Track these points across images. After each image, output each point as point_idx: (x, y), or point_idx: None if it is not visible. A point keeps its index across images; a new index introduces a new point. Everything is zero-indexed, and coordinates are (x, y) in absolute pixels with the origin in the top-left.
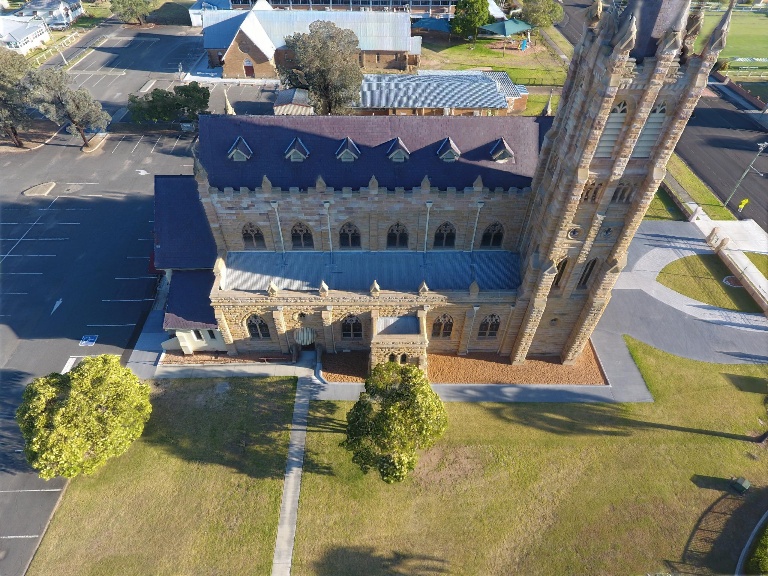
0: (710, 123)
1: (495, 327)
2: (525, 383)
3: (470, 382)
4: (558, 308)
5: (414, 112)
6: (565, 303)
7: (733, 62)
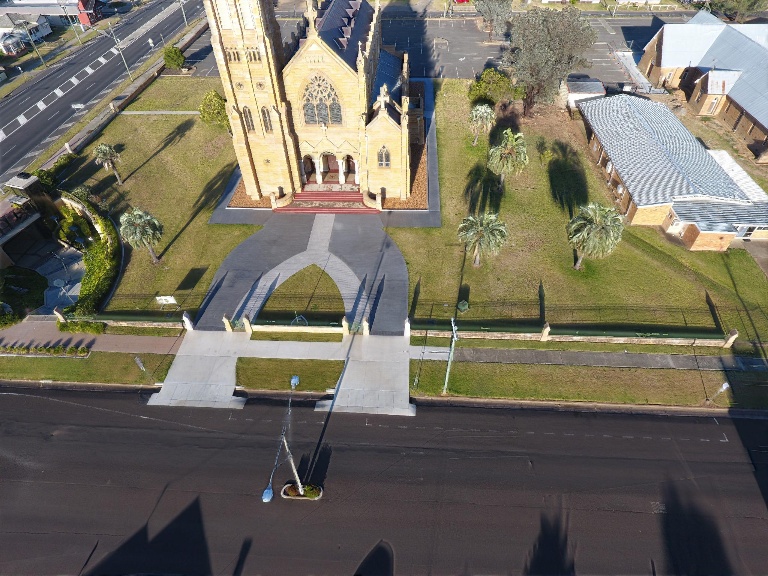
0: None
1: None
2: None
3: None
4: None
5: None
6: None
7: None
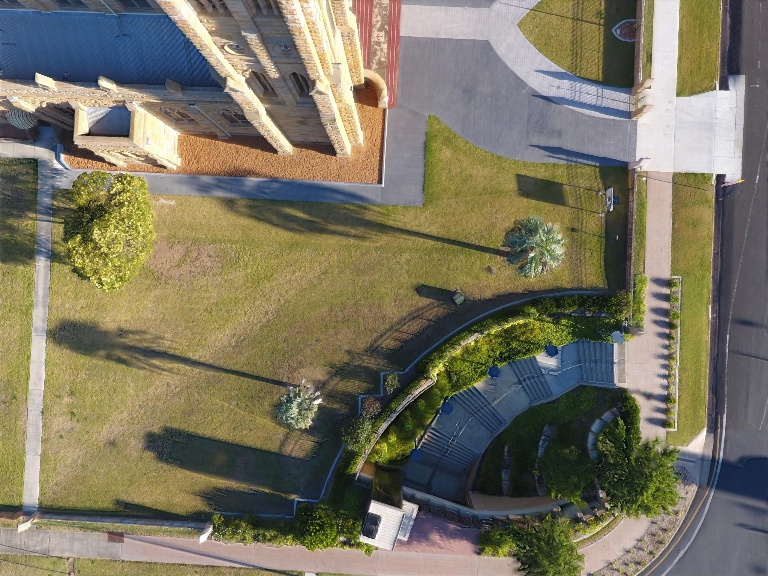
0: None
1: (242, 117)
2: (288, 178)
3: (227, 174)
4: (293, 112)
5: None
6: (296, 109)
7: None
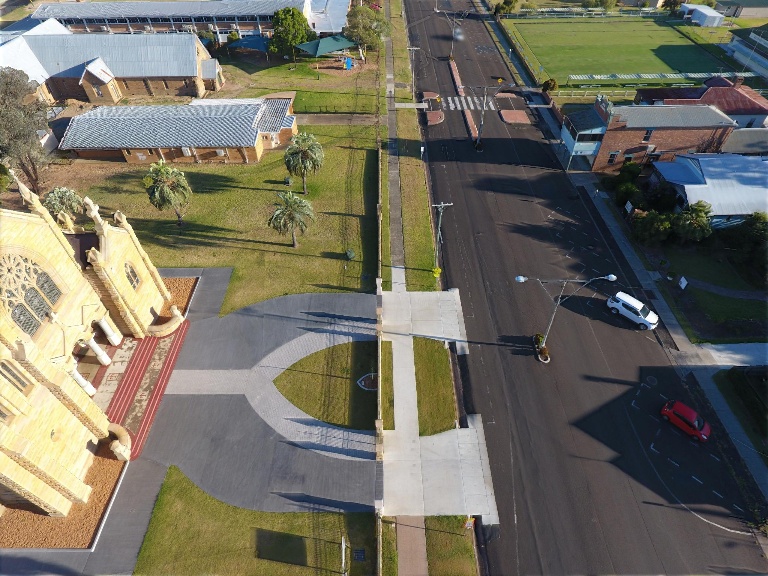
0: (496, 158)
1: None
2: None
3: None
4: None
5: (151, 152)
6: None
7: (570, 80)
